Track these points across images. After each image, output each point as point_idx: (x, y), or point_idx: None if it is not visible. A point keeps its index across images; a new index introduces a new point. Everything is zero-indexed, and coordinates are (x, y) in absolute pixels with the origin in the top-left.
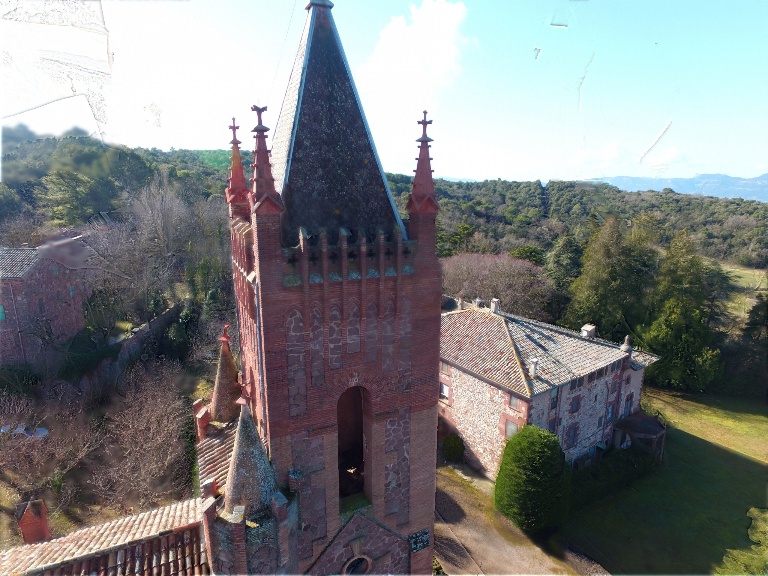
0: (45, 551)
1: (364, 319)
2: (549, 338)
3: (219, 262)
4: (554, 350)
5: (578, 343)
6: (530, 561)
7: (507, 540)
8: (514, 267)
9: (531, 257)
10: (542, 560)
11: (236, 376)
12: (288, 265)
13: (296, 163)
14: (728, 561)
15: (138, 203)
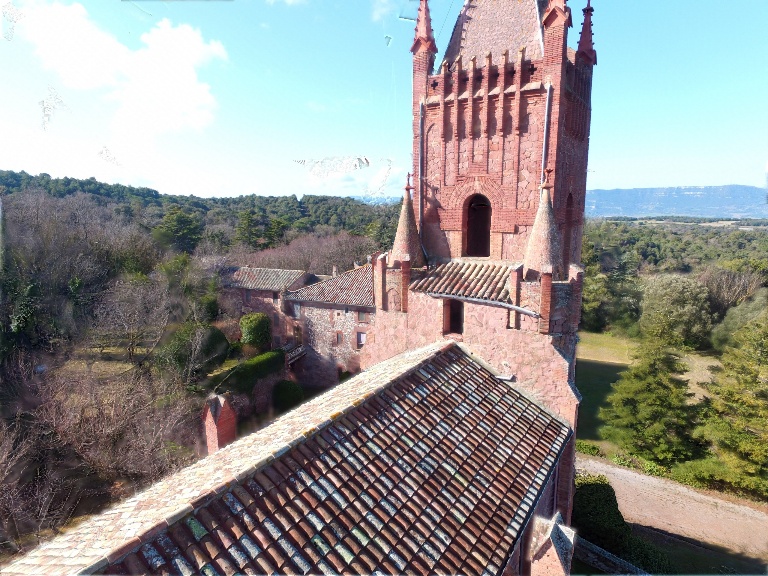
0: None
1: (578, 136)
2: None
3: (29, 251)
4: None
5: None
6: None
7: None
8: (355, 244)
9: (369, 233)
10: None
11: None
12: None
13: None
14: (614, 384)
15: None
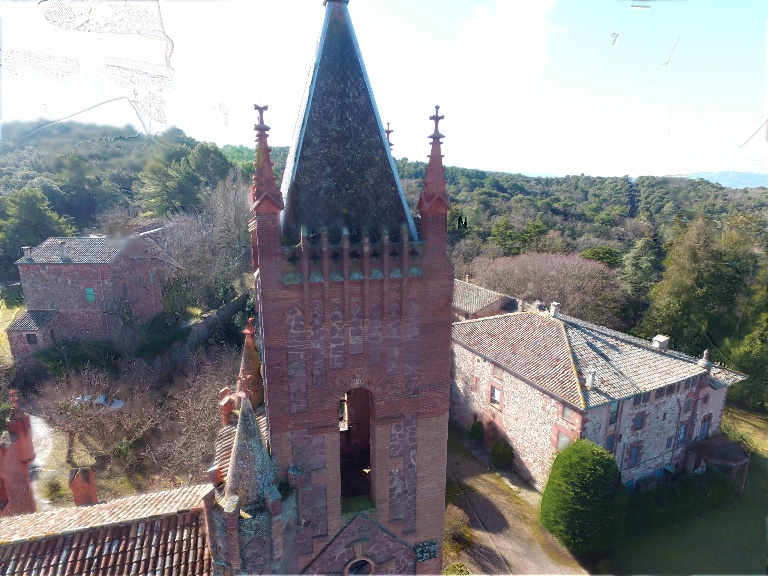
0: (85, 514)
1: (367, 320)
2: (613, 347)
3: None
4: (618, 360)
5: (647, 355)
6: None
7: (551, 558)
8: (584, 269)
9: (604, 259)
10: None
11: (259, 368)
12: (288, 263)
13: (304, 161)
14: None
15: (211, 197)
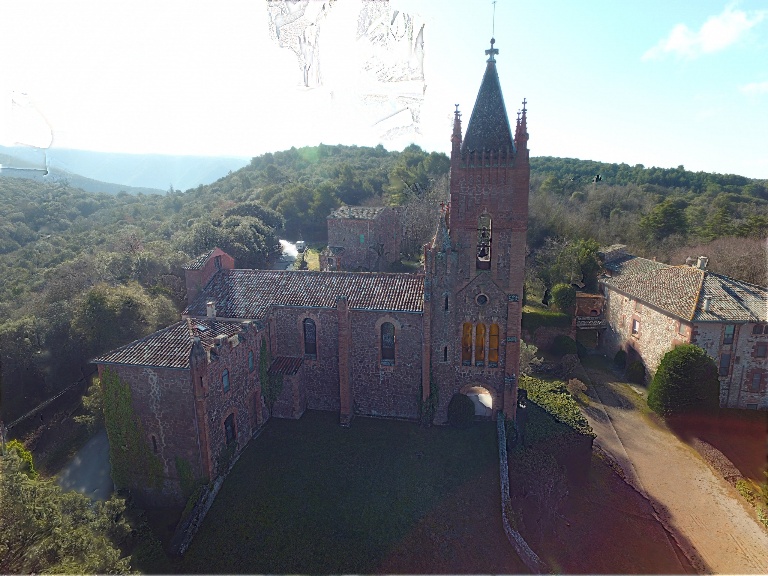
0: None
1: (491, 185)
2: (752, 293)
3: None
4: (750, 302)
5: None
6: (660, 438)
7: (649, 425)
8: None
9: None
10: (672, 441)
11: None
12: (462, 160)
13: (472, 124)
14: None
15: (438, 181)
